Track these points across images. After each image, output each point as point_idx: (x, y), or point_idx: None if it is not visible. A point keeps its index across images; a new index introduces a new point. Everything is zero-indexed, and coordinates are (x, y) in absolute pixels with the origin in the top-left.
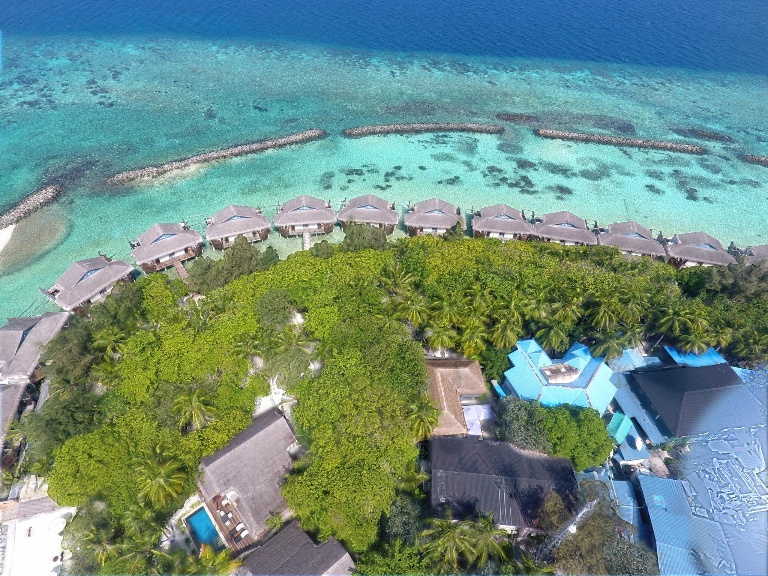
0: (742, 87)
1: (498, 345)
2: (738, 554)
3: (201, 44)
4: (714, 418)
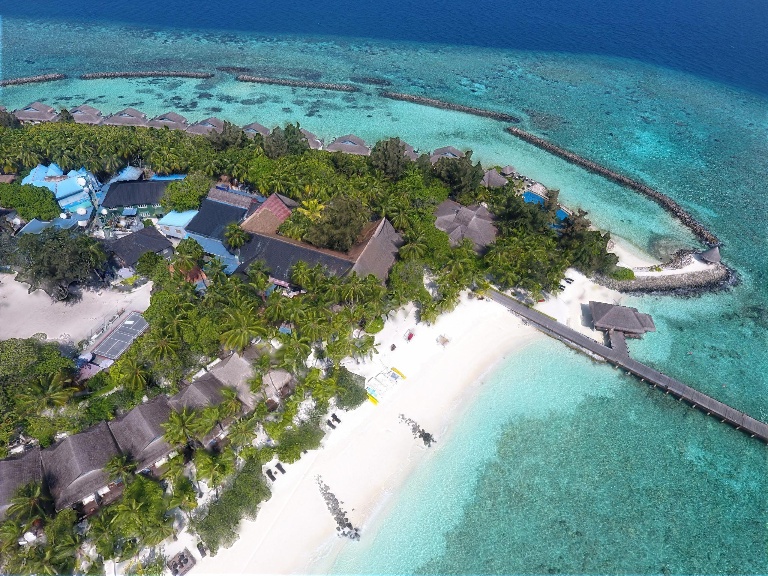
0: (448, 53)
1: (26, 165)
2: None
3: (21, 21)
4: (133, 197)
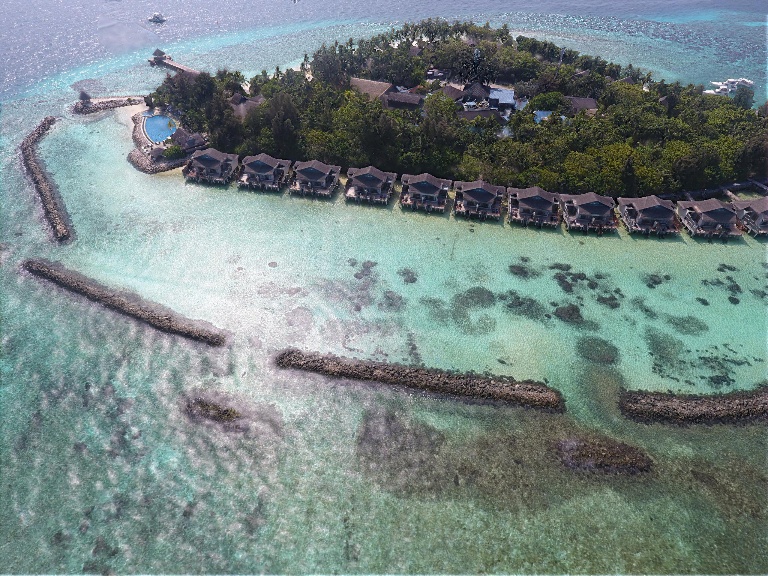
0: None
1: None
2: (488, 92)
3: None
4: None
